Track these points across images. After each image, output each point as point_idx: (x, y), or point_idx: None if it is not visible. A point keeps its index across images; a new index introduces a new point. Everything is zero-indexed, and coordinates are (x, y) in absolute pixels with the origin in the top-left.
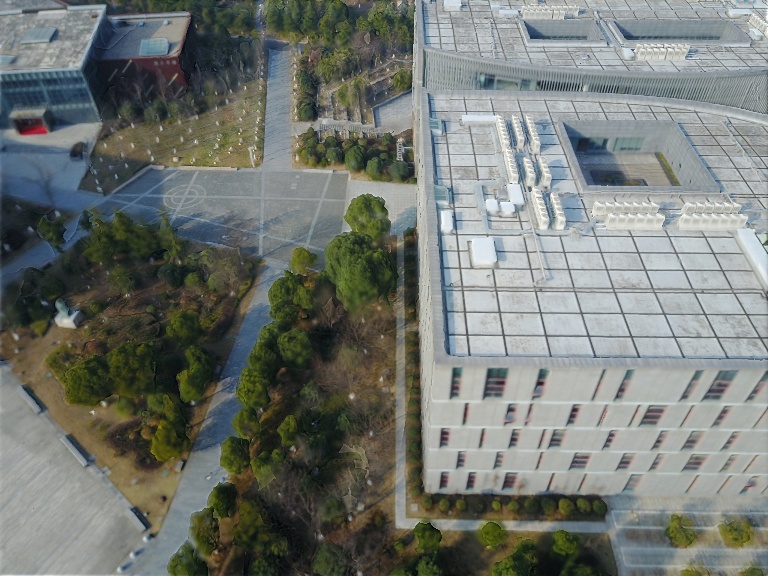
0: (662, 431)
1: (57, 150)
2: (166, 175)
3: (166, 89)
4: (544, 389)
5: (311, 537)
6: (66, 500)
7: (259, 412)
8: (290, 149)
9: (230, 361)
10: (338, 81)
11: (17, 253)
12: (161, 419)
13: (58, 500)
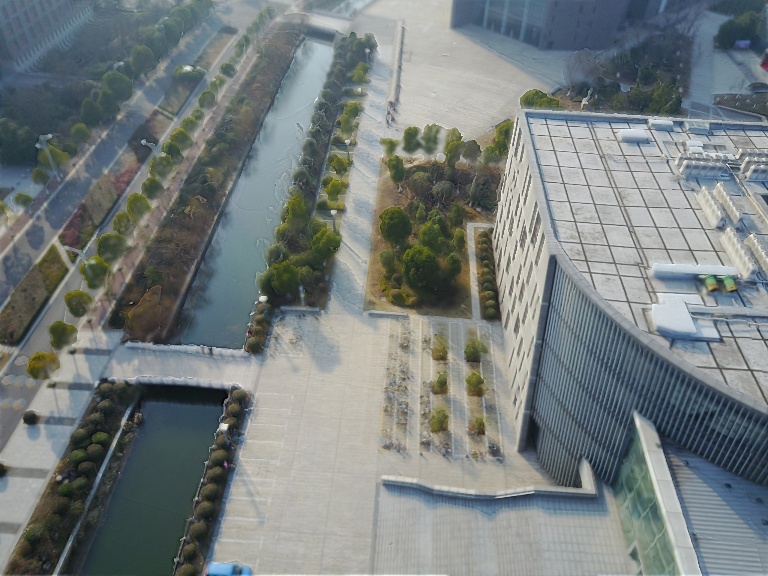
0: None
1: None
2: None
3: None
4: None
5: None
6: (473, 124)
7: None
8: None
9: None
10: None
11: (636, 84)
12: None
13: (473, 122)
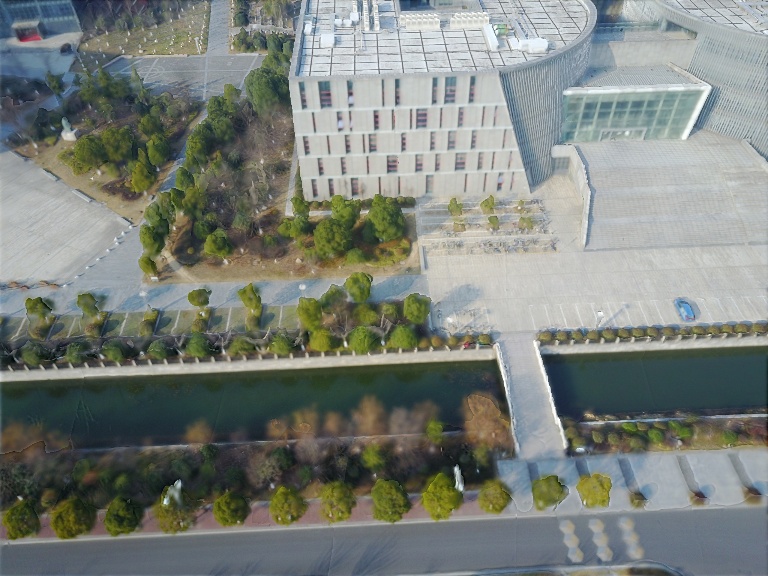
0: (431, 133)
1: (50, 50)
2: (134, 61)
3: (131, 7)
4: (354, 98)
5: (232, 219)
6: (79, 216)
7: (202, 172)
8: (227, 43)
9: (183, 151)
10: (266, 0)
11: None
12: (137, 162)
13: (74, 216)
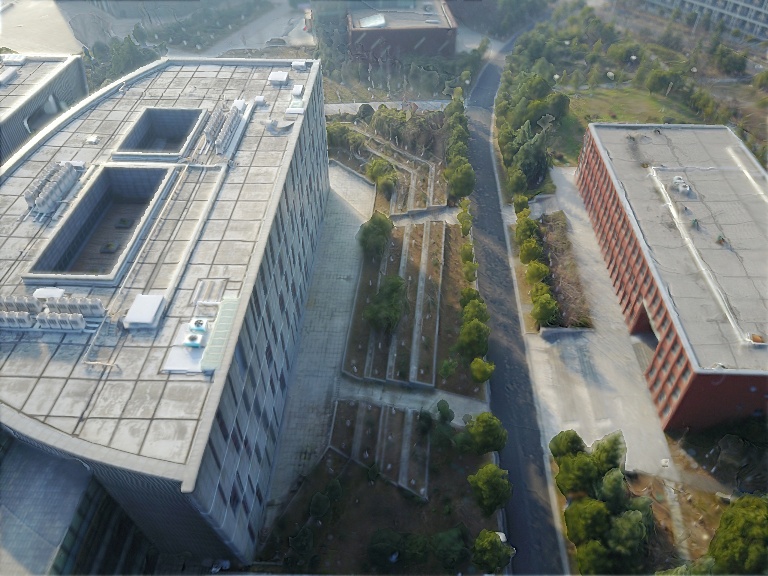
0: None
1: None
2: None
3: None
4: None
5: None
6: None
7: None
8: None
9: None
10: (372, 129)
11: None
12: None
13: None
